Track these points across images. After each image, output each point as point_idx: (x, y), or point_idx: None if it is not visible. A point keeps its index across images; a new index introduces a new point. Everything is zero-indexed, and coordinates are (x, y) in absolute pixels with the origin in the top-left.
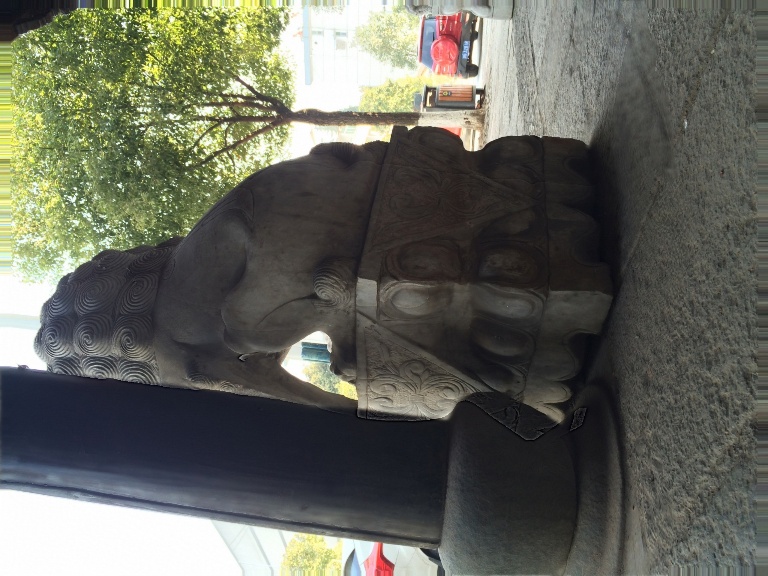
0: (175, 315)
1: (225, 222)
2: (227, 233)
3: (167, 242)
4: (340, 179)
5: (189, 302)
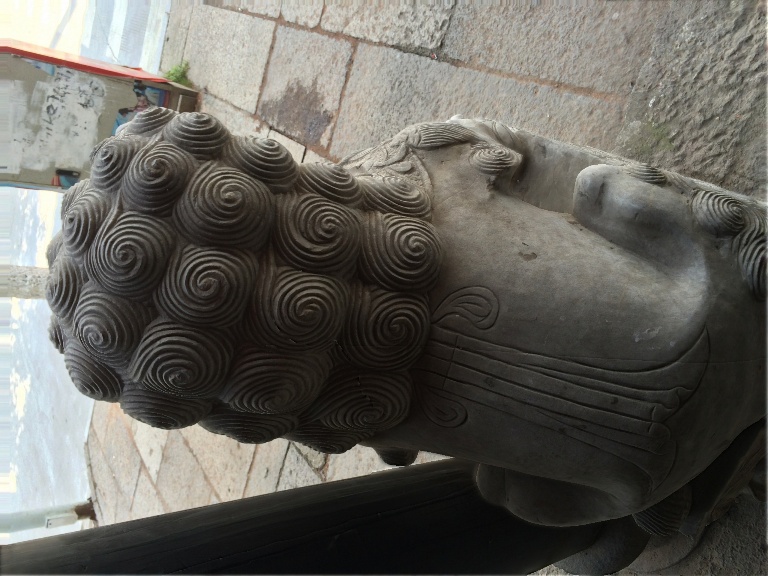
0: None
1: (615, 477)
2: (605, 483)
3: (410, 280)
4: (764, 409)
5: None
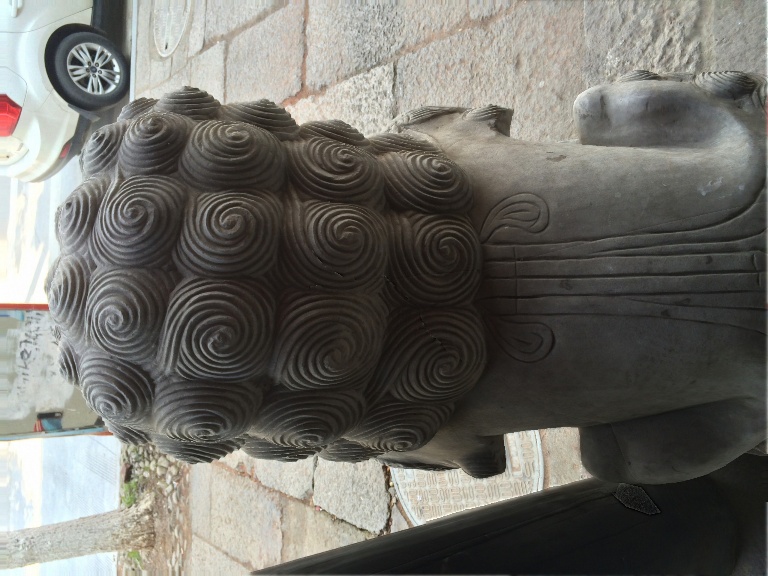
0: (513, 417)
1: (744, 357)
2: (735, 374)
3: (446, 199)
4: None
5: (559, 412)
